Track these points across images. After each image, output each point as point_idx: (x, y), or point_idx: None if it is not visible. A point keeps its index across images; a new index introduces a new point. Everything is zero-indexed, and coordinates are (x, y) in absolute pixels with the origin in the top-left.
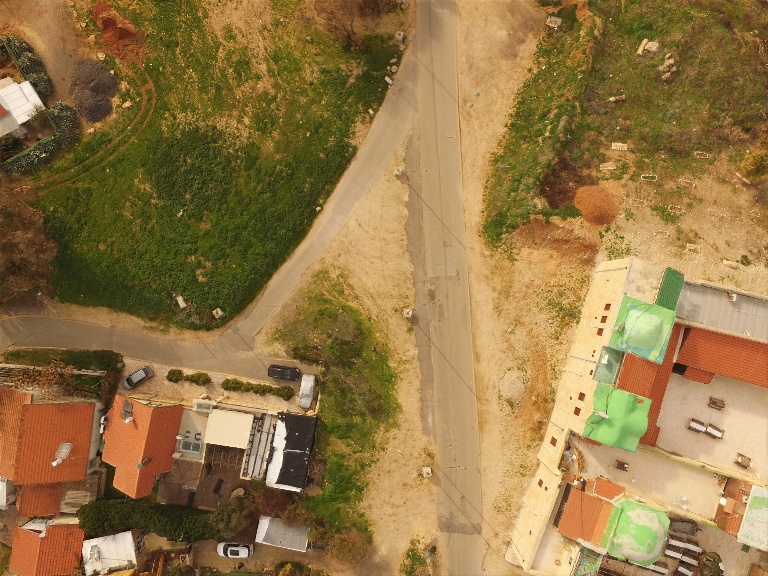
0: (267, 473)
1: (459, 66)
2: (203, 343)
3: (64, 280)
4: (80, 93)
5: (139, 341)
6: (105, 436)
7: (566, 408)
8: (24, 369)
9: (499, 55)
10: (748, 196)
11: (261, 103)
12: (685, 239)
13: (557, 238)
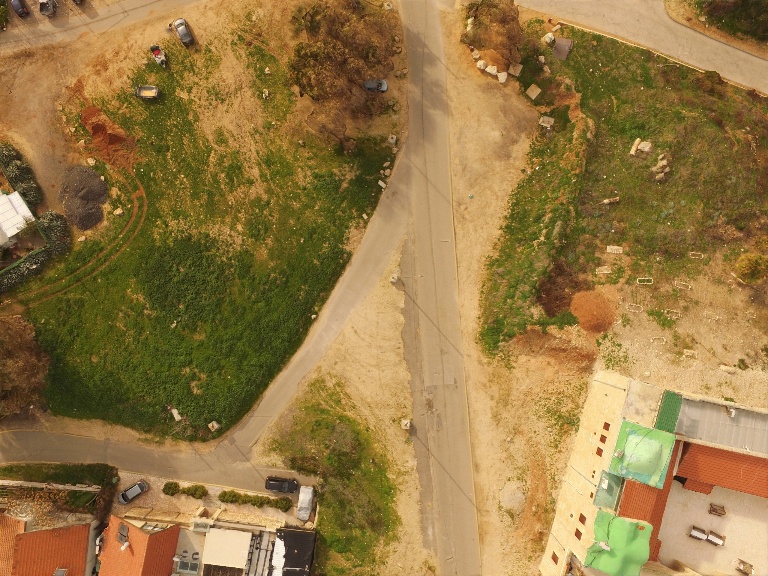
0: None
1: (452, 168)
2: (199, 454)
3: (57, 394)
4: (70, 201)
5: (134, 454)
6: (101, 557)
7: (567, 525)
8: (17, 487)
9: (492, 156)
10: (744, 296)
11: (254, 209)
12: (682, 345)
13: (554, 347)
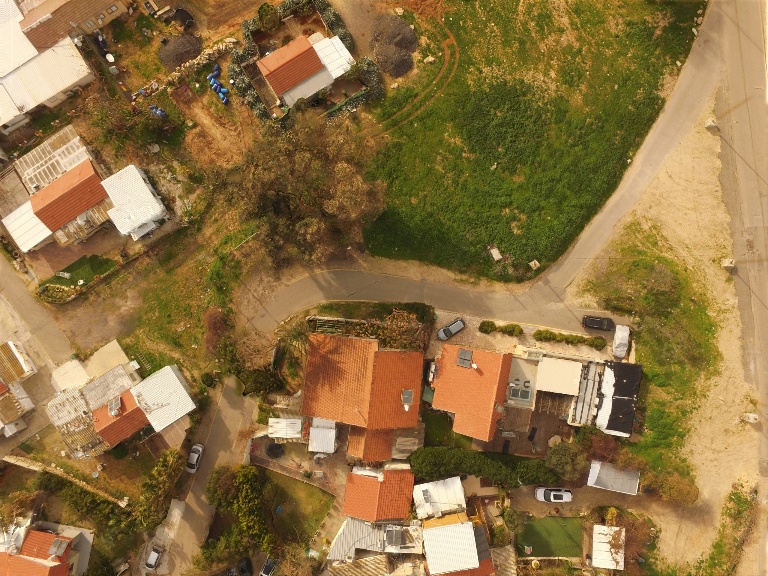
0: (597, 419)
1: (764, 17)
2: (513, 295)
3: (379, 234)
4: (384, 48)
5: (450, 294)
6: (435, 384)
7: None
8: None
9: None
10: None
11: (566, 56)
12: None
13: None
